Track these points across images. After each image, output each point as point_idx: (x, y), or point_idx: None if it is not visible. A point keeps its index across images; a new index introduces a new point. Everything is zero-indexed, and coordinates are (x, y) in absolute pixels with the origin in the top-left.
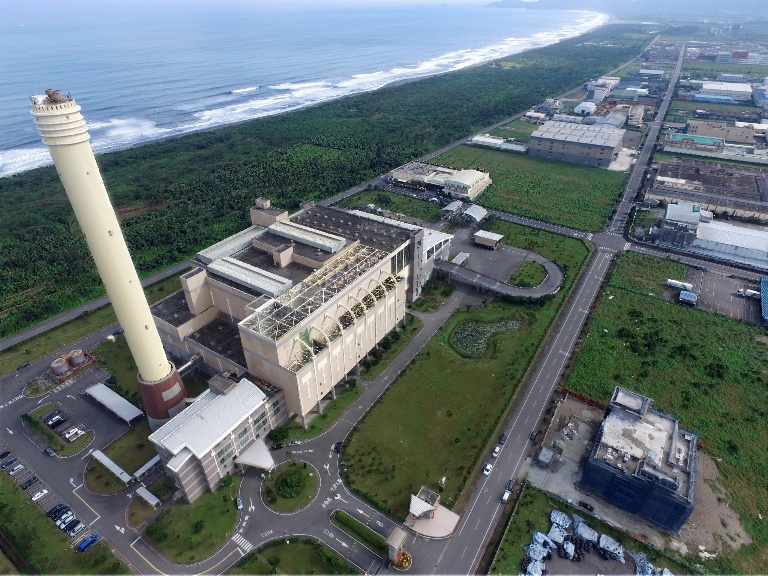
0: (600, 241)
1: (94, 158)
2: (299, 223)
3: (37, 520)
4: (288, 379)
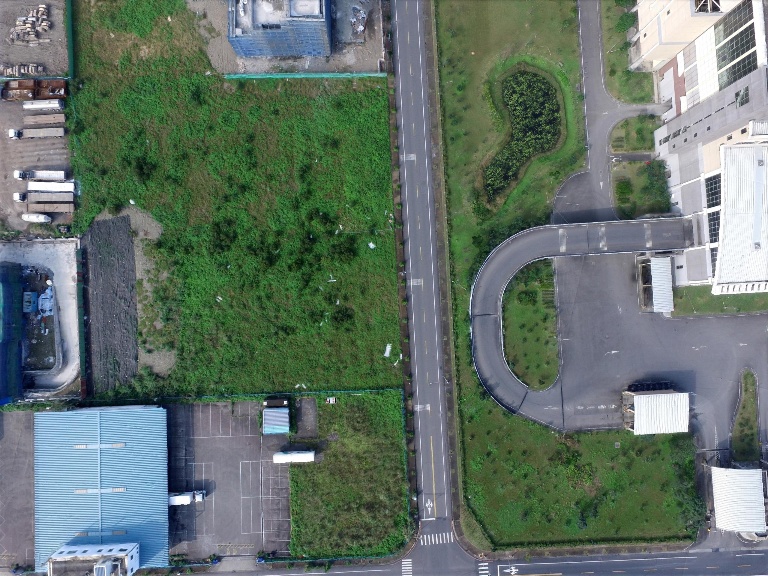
0: (461, 568)
1: None
2: None
3: None
4: None
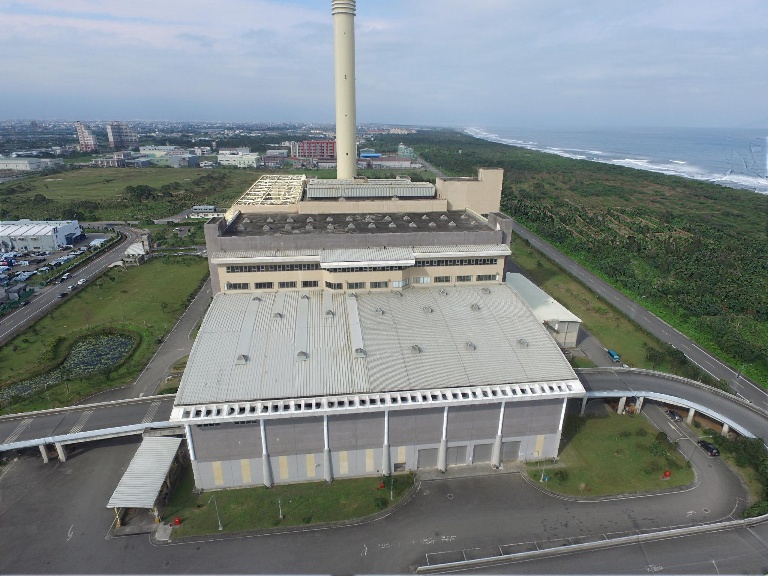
0: None
1: (339, 27)
2: (425, 201)
3: None
4: None
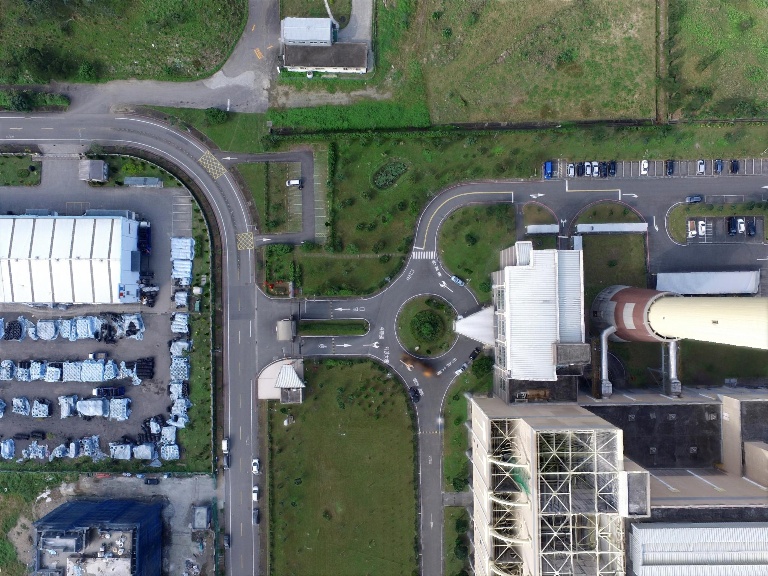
0: None
1: None
2: None
3: (616, 153)
4: (502, 413)
